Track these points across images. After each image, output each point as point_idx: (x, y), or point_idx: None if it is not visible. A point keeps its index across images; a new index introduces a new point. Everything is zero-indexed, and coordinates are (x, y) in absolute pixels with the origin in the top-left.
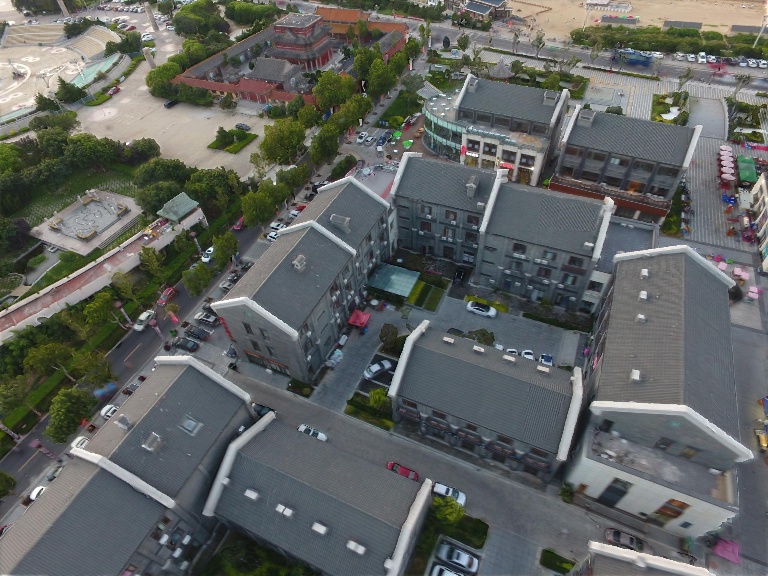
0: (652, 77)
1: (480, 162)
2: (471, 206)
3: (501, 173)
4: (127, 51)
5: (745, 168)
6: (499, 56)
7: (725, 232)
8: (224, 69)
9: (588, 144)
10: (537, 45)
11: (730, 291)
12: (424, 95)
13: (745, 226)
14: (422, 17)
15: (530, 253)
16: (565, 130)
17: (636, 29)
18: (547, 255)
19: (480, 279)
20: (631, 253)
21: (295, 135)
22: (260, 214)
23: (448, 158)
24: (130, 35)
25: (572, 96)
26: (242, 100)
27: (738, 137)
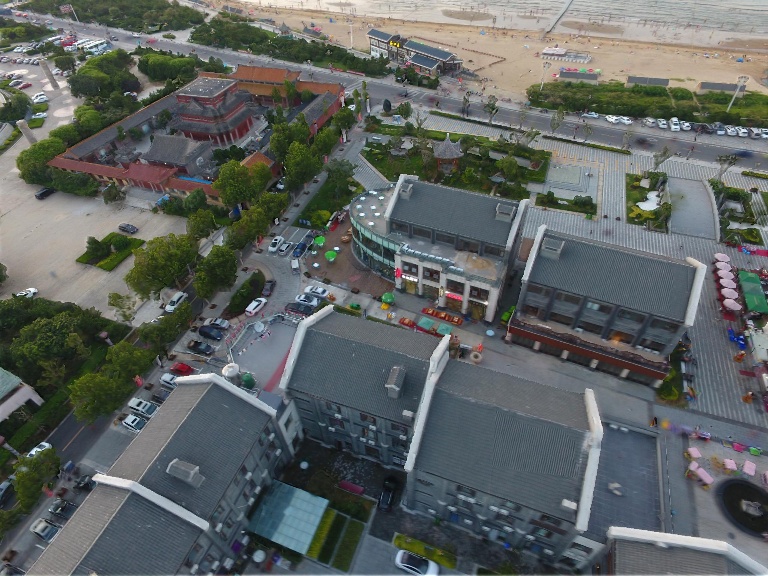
0: (622, 150)
1: (420, 287)
2: (394, 413)
3: (436, 364)
4: (8, 119)
5: (751, 291)
6: (448, 122)
7: (741, 396)
8: (121, 143)
9: (556, 284)
10: (490, 111)
11: (765, 510)
12: (358, 177)
13: (767, 390)
14: (362, 71)
15: (482, 498)
16: (526, 228)
17: (598, 85)
18: (507, 503)
19: (415, 505)
20: (636, 533)
21: (175, 260)
22: (100, 405)
23: (382, 275)
24: (13, 99)
25: (532, 179)
26: (134, 188)
27: (733, 239)
